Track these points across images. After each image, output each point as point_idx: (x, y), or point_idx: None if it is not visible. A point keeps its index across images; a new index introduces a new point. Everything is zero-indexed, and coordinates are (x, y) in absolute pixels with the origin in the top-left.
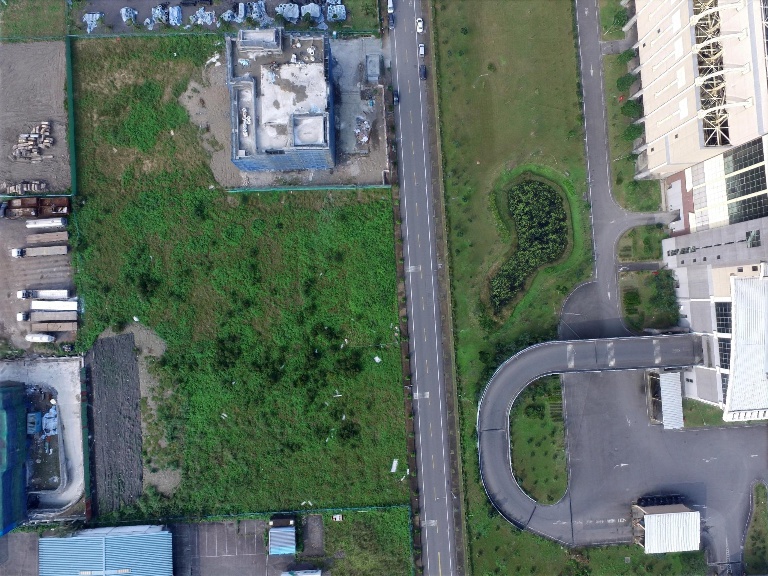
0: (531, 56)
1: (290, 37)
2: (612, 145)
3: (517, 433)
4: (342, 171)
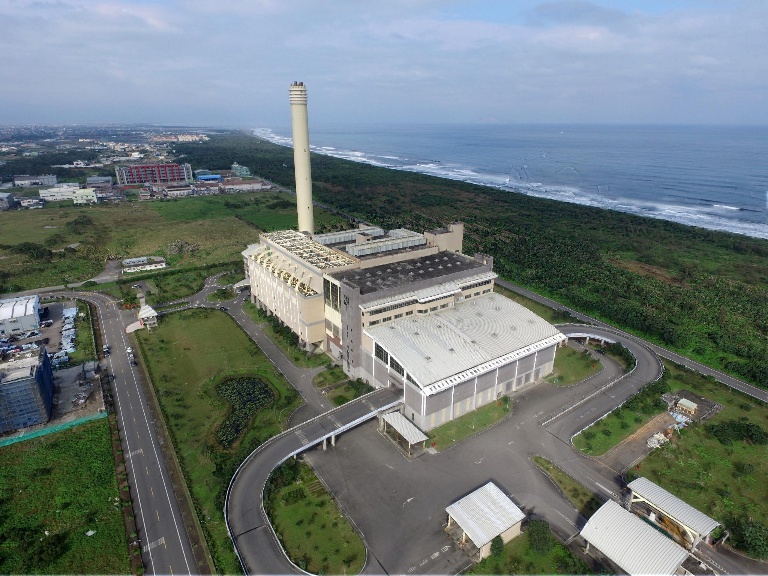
0: (213, 339)
1: (10, 353)
2: (284, 350)
3: (282, 524)
4: (57, 423)
